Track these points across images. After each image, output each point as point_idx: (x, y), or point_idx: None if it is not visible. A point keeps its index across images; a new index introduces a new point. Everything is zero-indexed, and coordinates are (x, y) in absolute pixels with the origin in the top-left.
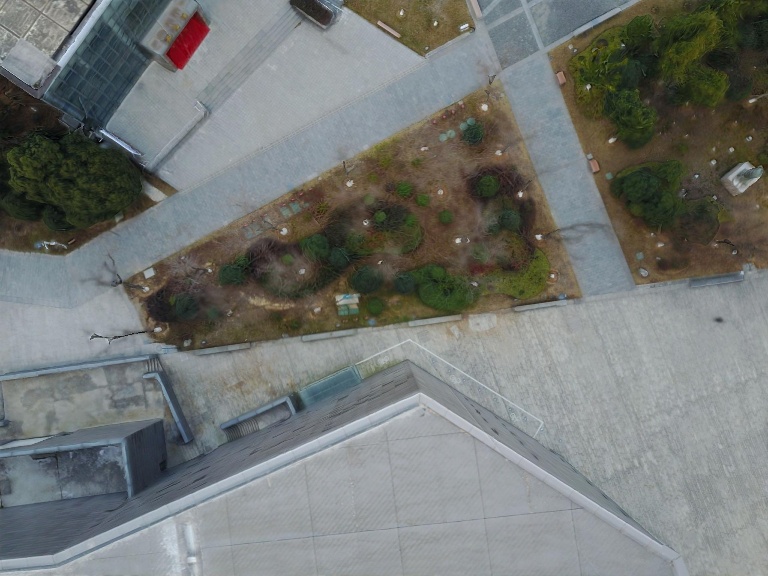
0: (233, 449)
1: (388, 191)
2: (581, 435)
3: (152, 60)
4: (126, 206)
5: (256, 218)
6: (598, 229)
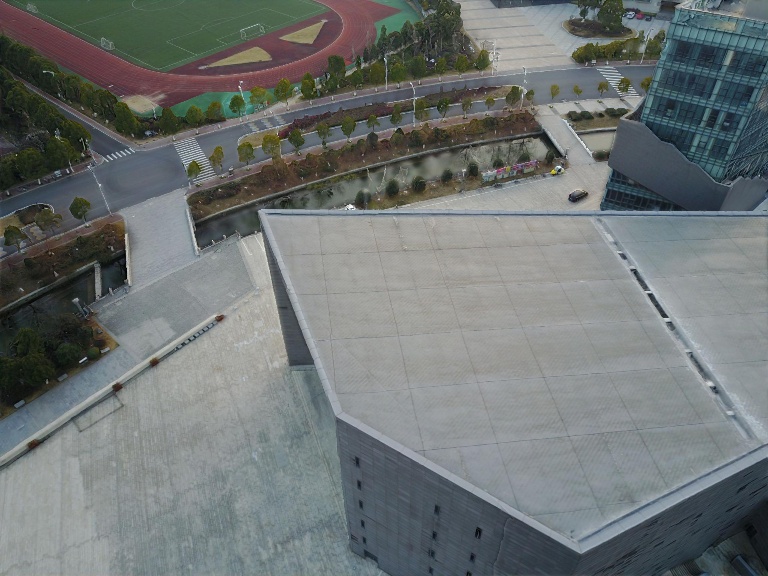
0: None
1: None
2: (333, 575)
3: None
4: None
5: None
6: None
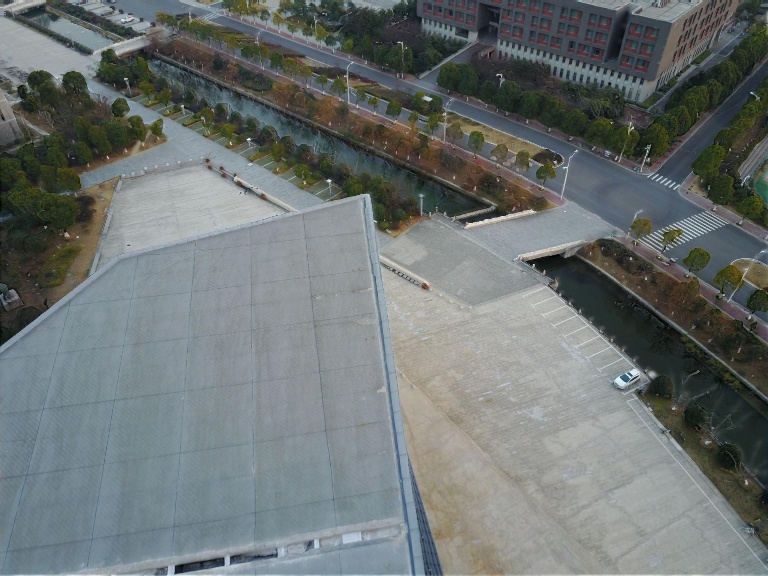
0: None
1: None
2: None
3: None
4: None
5: None
6: None
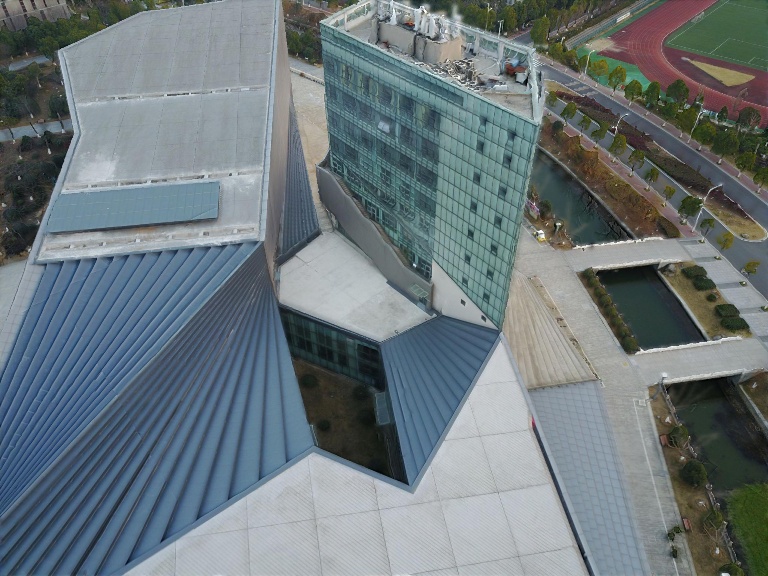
0: None
1: (8, 173)
2: None
3: None
4: None
5: None
6: None
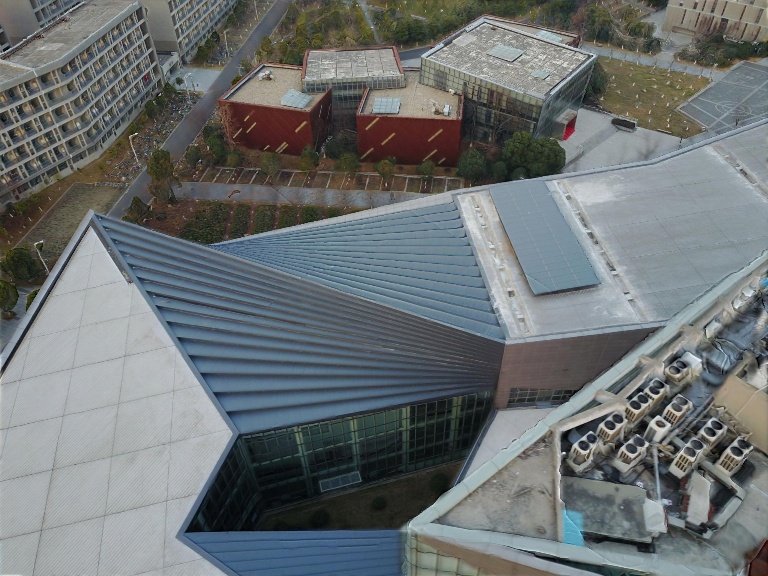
0: None
1: None
2: None
3: (550, 137)
4: None
5: None
6: None
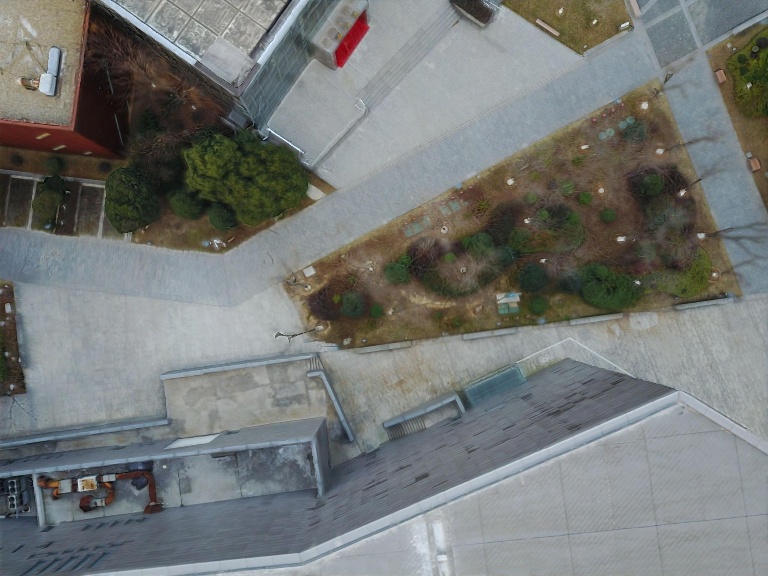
0: (419, 447)
1: (549, 189)
2: None
3: (312, 58)
4: (297, 204)
5: (416, 216)
6: (758, 227)
